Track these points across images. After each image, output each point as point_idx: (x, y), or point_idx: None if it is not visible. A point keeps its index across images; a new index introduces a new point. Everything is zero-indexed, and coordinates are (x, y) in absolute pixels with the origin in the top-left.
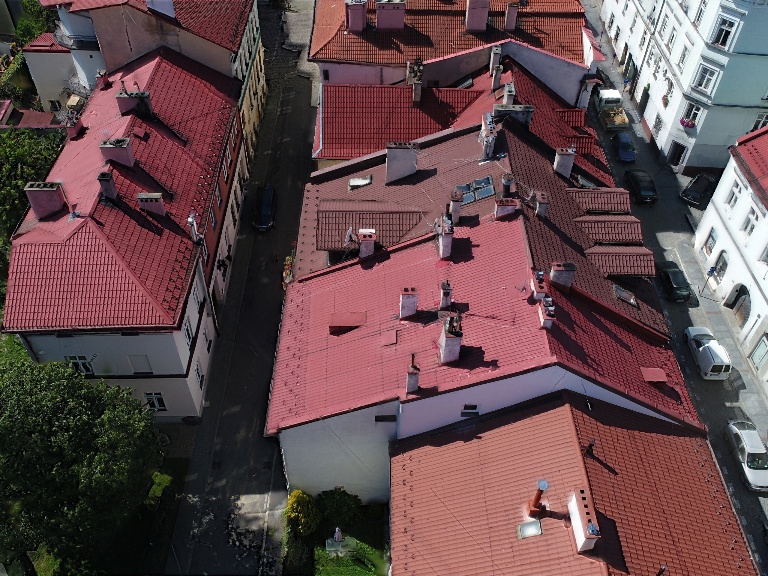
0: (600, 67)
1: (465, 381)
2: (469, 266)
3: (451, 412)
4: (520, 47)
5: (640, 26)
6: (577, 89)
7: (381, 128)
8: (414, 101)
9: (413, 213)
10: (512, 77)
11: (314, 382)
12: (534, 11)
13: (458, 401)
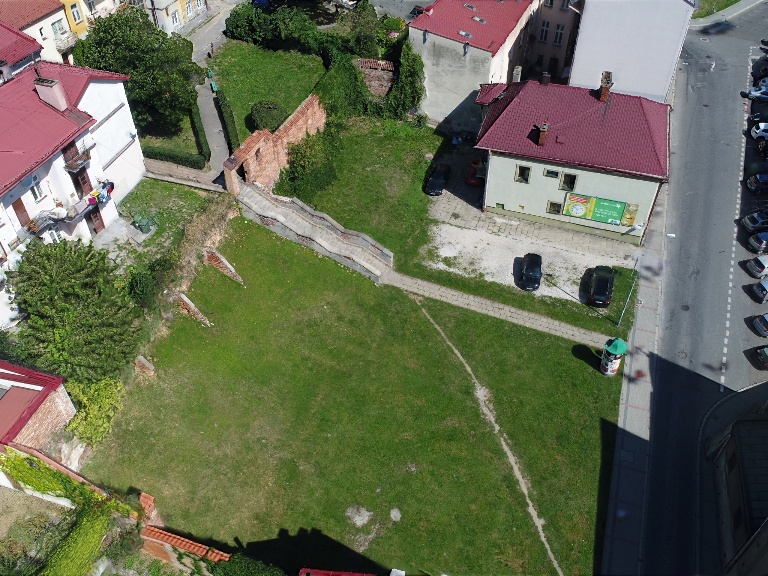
0: None
1: None
2: None
3: None
4: None
5: None
6: None
7: None
8: None
9: None
10: None
11: (2, 44)
12: None
13: None
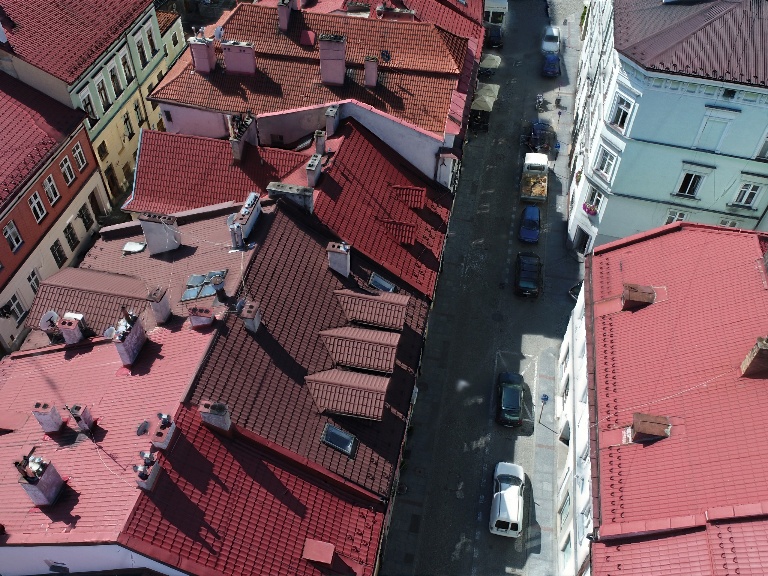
0: (552, 122)
1: (32, 537)
2: (139, 382)
3: (38, 563)
4: (363, 109)
5: (586, 84)
6: (434, 162)
7: (197, 184)
8: (234, 159)
9: (140, 300)
10: (340, 144)
11: None
12: (401, 67)
13: (35, 555)
